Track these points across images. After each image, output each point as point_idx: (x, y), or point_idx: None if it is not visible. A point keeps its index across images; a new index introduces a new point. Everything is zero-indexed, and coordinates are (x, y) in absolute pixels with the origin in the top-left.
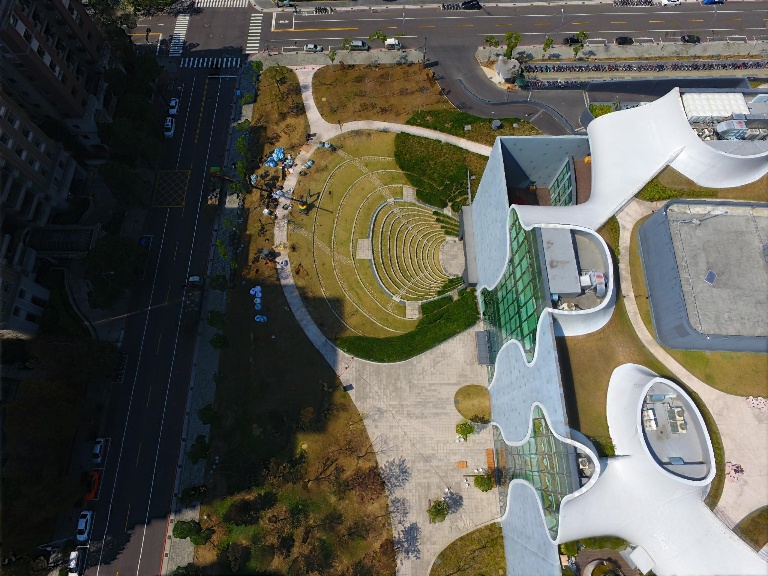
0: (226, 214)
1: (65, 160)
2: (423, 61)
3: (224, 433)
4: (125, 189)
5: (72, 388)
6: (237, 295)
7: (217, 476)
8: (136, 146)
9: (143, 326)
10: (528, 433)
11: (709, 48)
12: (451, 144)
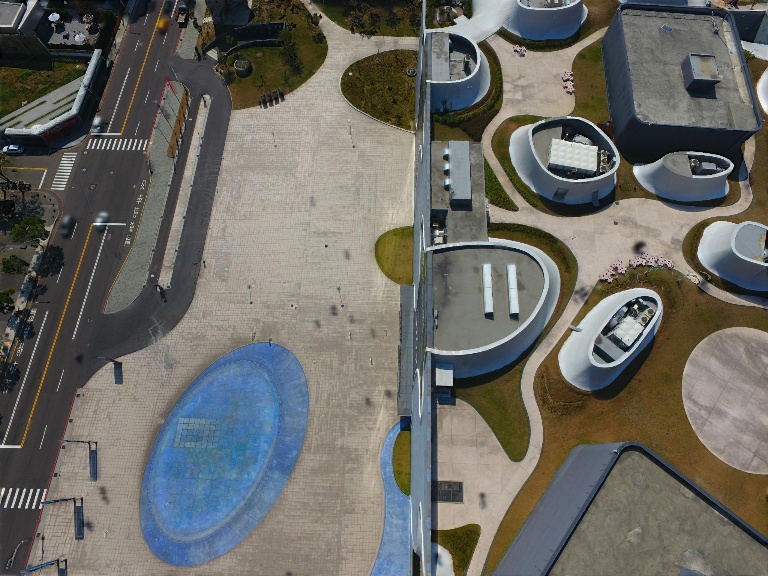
0: None
1: None
2: None
3: None
4: None
5: None
6: None
7: None
8: None
9: None
10: None
11: None
12: None
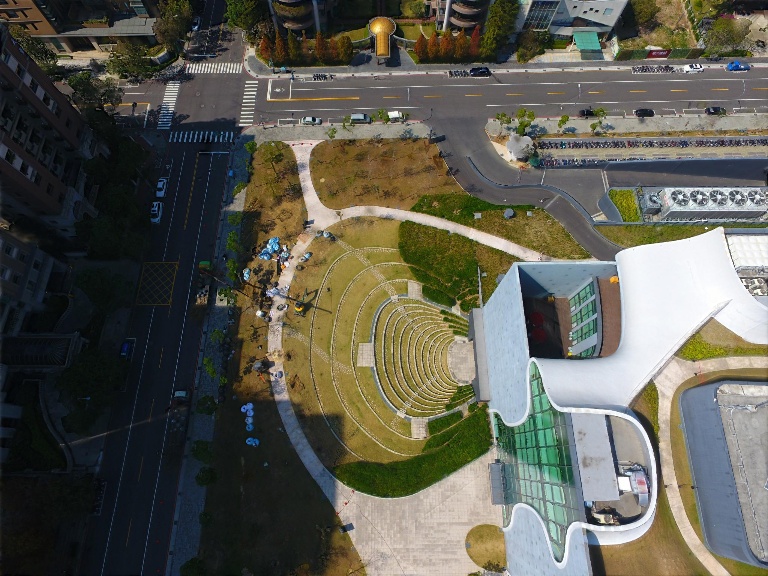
0: (216, 314)
1: (41, 259)
2: (429, 138)
3: None
4: (105, 297)
5: (42, 534)
6: (227, 411)
7: None
8: (117, 246)
9: (124, 447)
10: None
11: (736, 121)
12: (460, 235)
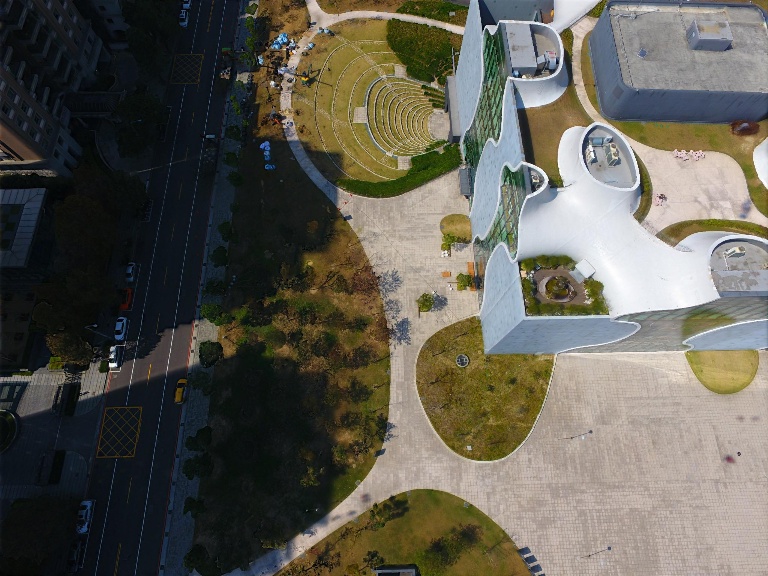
0: (237, 89)
1: (93, 37)
2: None
3: (240, 258)
4: (148, 56)
5: (108, 214)
6: (248, 152)
7: (234, 291)
8: (157, 22)
9: (166, 177)
10: (497, 202)
11: None
12: (437, 28)
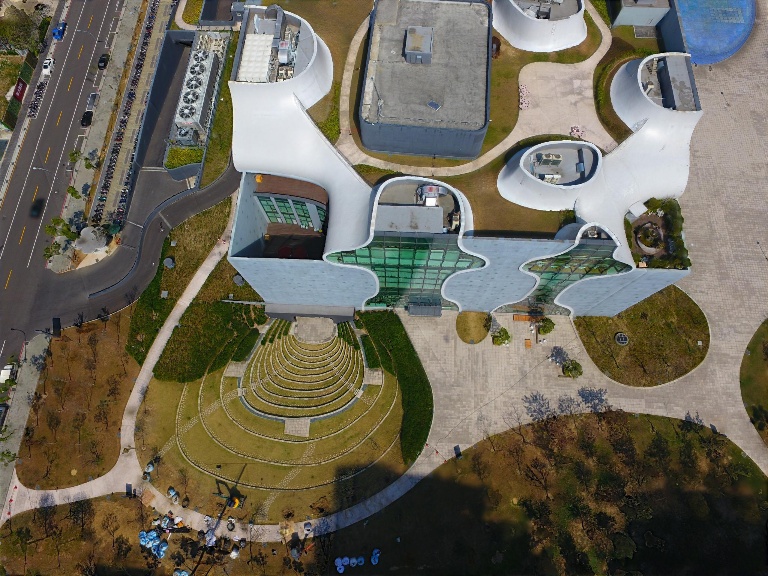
0: None
1: None
2: None
3: None
4: None
5: None
6: None
7: None
8: None
9: None
10: (536, 278)
11: (119, 50)
12: (182, 315)
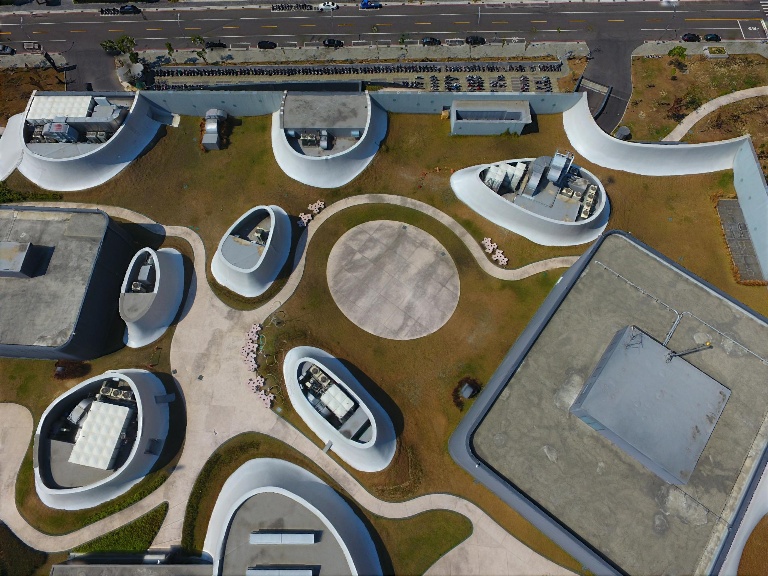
0: None
1: None
2: None
3: None
4: None
5: None
6: None
7: None
8: None
9: None
10: None
11: (349, 52)
12: None
